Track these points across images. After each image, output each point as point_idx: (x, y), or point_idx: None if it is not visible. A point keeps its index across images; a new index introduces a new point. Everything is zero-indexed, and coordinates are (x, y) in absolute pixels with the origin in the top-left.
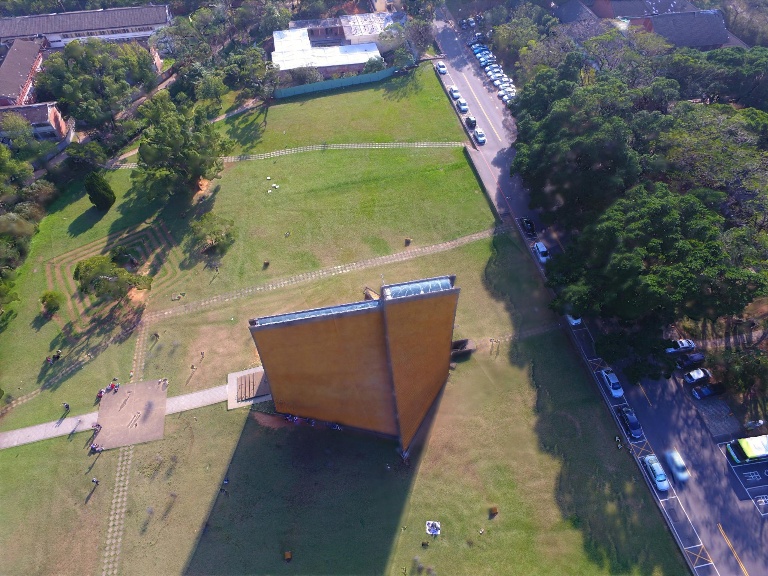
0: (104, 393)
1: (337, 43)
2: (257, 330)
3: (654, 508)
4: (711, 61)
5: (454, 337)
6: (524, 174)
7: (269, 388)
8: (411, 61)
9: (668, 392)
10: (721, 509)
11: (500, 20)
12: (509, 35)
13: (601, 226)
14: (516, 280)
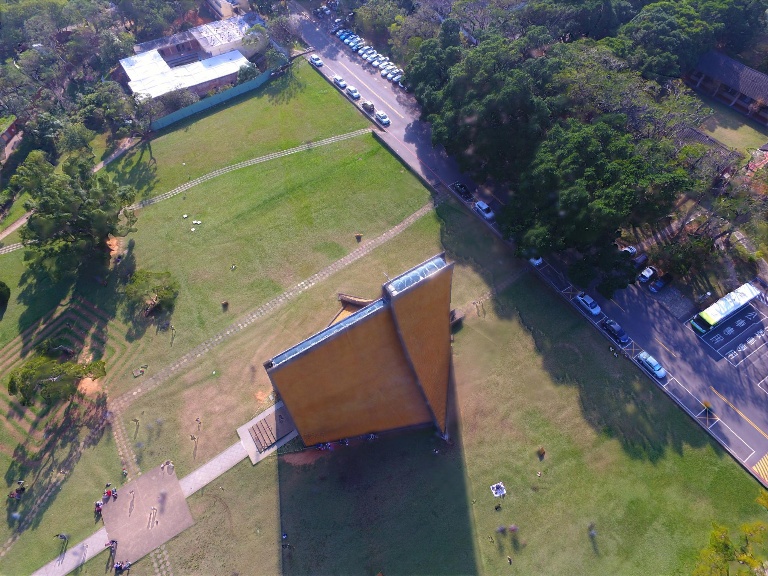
0: (102, 505)
1: (194, 58)
2: (275, 371)
3: (662, 394)
4: (559, 4)
5: None
6: (447, 142)
7: (294, 426)
8: (285, 60)
9: (632, 295)
10: (707, 374)
11: (355, 2)
12: (372, 15)
13: (539, 170)
14: (472, 242)
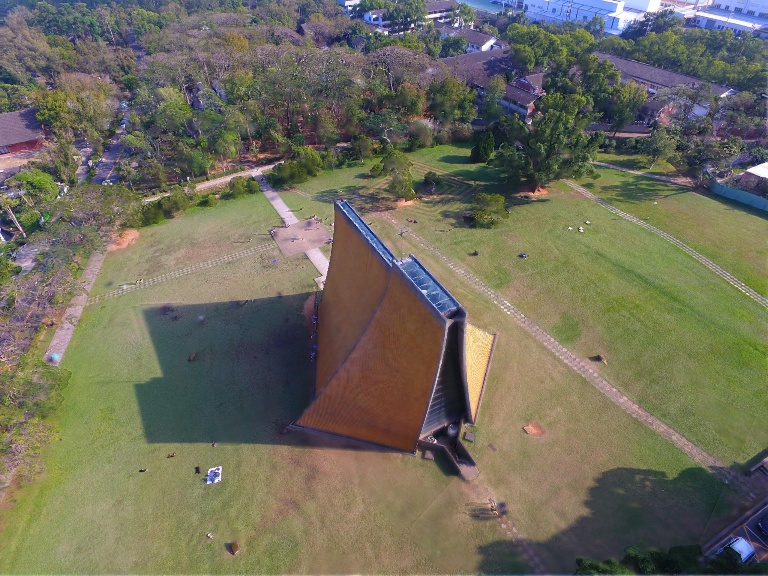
0: (314, 218)
1: None
2: None
3: None
4: None
5: (474, 448)
6: None
7: None
8: None
9: None
10: None
11: None
12: None
13: None
14: (633, 521)
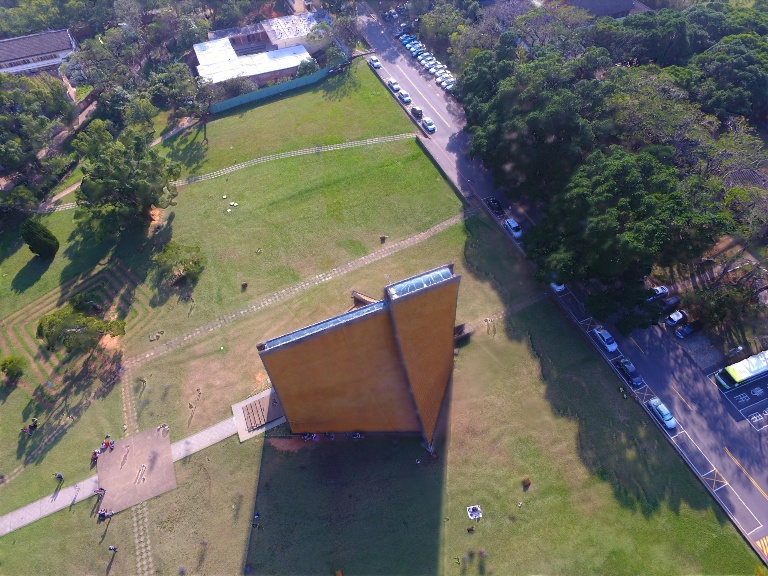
0: (99, 454)
1: (262, 49)
2: (267, 354)
3: (668, 446)
4: (628, 27)
5: None
6: (485, 155)
7: (283, 411)
8: (344, 59)
9: (655, 337)
10: (723, 433)
11: (423, 9)
12: (436, 22)
13: (571, 194)
14: (496, 258)
